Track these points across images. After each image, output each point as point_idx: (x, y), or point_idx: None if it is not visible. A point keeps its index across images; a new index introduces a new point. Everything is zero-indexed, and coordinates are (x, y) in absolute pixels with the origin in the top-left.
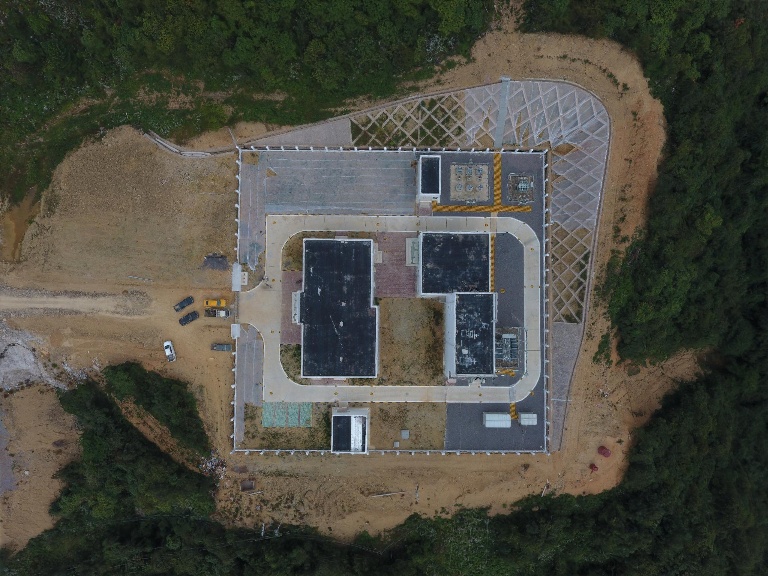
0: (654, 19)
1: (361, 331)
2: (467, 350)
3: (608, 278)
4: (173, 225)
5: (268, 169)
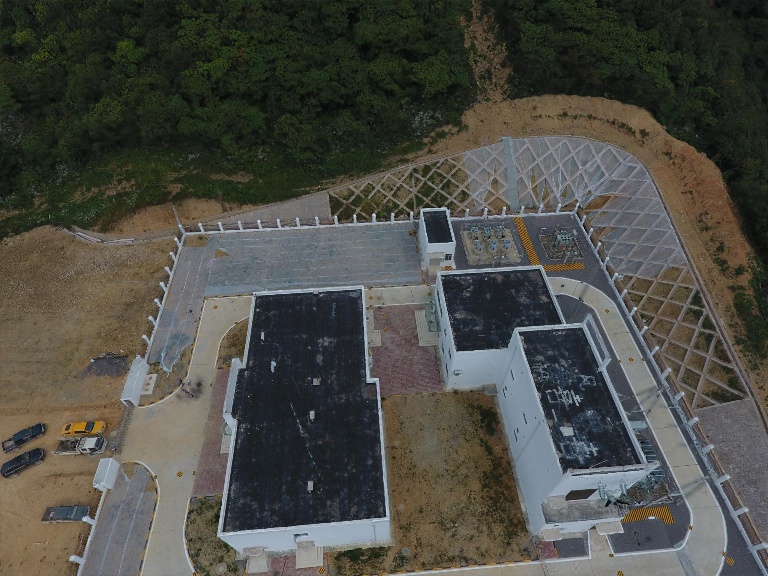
0: (647, 68)
1: (351, 427)
2: (570, 428)
3: (749, 323)
4: (58, 322)
5: (218, 250)
